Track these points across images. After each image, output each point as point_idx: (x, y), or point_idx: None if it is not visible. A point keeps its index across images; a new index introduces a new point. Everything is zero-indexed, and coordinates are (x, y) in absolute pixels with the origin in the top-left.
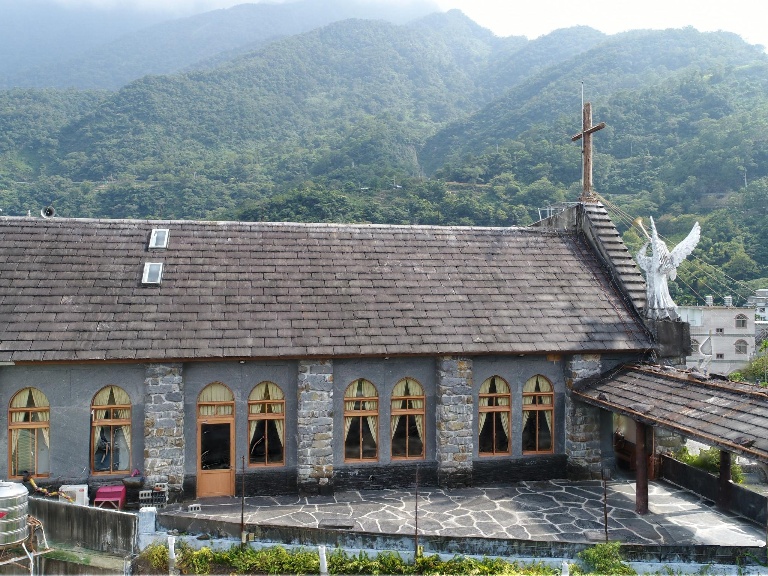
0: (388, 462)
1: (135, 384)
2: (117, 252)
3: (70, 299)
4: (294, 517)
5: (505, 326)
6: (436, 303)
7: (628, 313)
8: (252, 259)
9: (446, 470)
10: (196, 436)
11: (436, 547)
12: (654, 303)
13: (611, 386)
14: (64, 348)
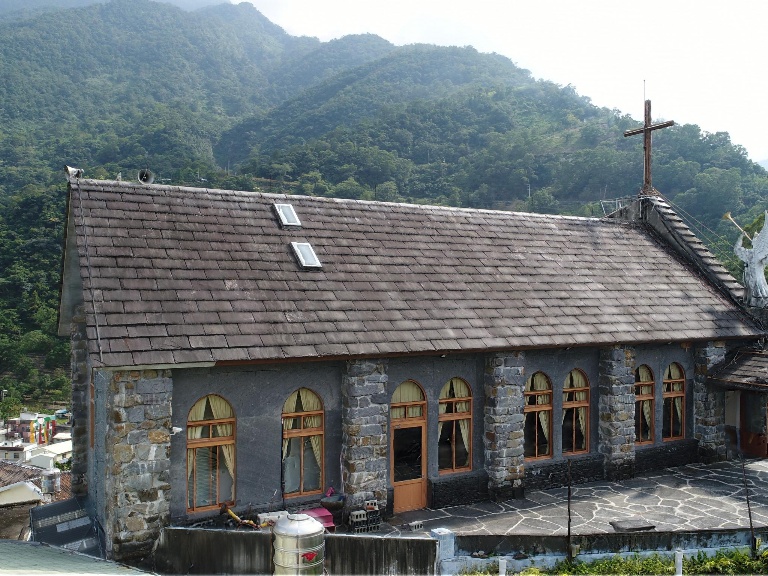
0: (562, 458)
1: (329, 385)
2: (250, 229)
3: (235, 284)
4: (532, 525)
5: (651, 314)
6: (583, 291)
7: (729, 302)
8: (393, 242)
9: (615, 462)
10: (390, 443)
11: (766, 538)
12: (758, 292)
13: (748, 370)
14: (267, 344)
